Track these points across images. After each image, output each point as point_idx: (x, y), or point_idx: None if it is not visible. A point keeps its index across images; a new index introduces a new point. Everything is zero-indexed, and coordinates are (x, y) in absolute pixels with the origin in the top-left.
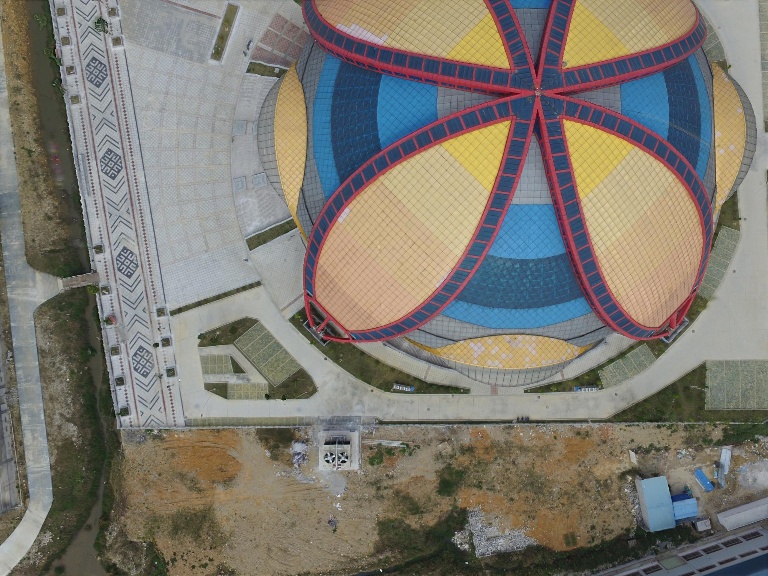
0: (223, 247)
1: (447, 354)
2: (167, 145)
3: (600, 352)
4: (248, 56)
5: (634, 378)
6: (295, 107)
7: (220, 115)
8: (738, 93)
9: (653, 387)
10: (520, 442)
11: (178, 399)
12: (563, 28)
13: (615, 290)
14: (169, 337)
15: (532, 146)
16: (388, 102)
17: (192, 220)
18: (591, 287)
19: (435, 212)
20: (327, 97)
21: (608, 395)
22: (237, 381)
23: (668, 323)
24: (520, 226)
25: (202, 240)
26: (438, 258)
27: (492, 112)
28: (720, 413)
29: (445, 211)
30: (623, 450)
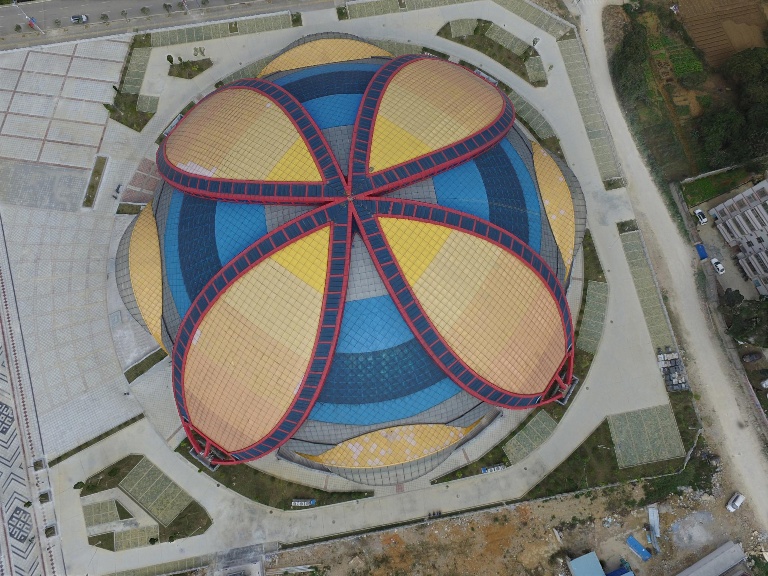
0: (103, 384)
1: (328, 460)
2: (42, 292)
3: (500, 426)
4: (119, 198)
5: (540, 448)
6: (148, 241)
7: (94, 256)
8: (557, 164)
9: (561, 454)
10: (437, 541)
11: (60, 561)
12: (366, 139)
13: (474, 366)
14: (48, 491)
15: (357, 245)
16: (224, 225)
17: (70, 362)
18: (447, 367)
19: (276, 321)
20: (174, 228)
21: (518, 471)
22: (124, 528)
23: (558, 385)
24: (363, 320)
25: (81, 381)
26: (289, 365)
27: (311, 221)
28: (635, 469)
29: (285, 319)
30: (547, 529)
